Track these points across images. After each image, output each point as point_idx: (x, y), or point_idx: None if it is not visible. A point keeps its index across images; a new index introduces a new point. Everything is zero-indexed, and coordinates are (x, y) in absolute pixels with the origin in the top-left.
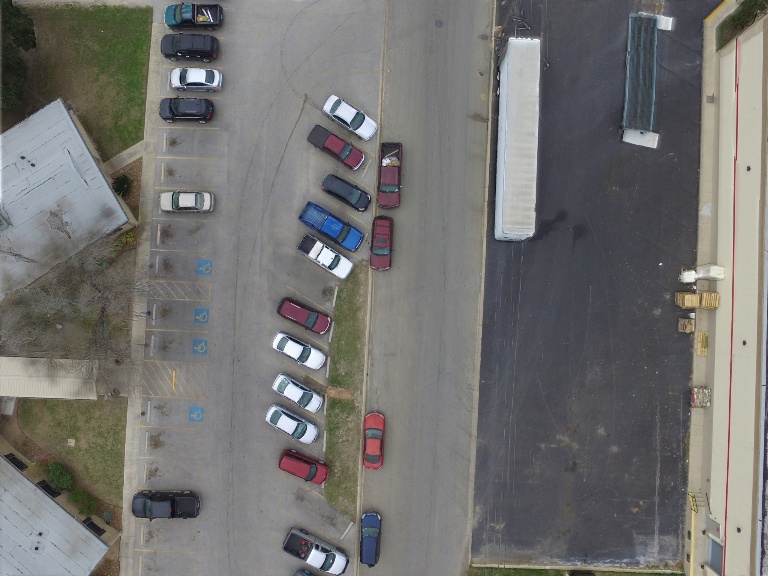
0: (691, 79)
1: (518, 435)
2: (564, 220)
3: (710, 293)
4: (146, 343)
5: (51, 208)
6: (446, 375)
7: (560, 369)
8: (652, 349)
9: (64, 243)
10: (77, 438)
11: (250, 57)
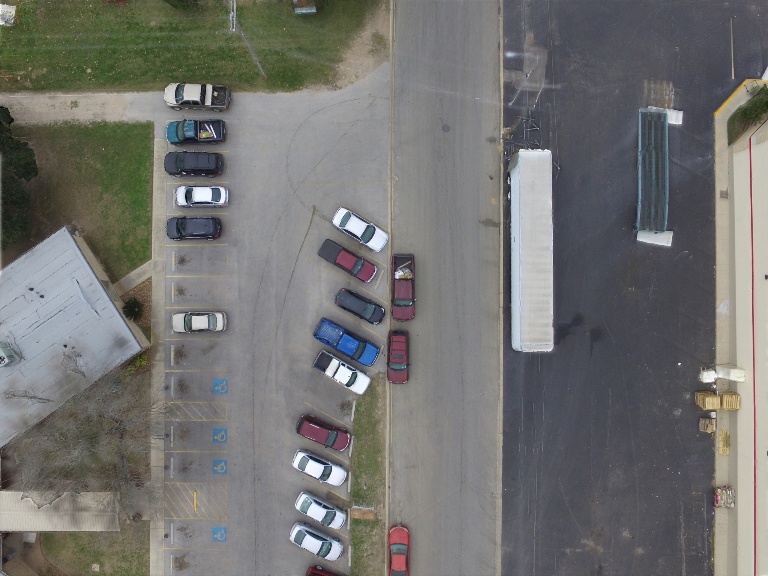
0: (704, 174)
1: (543, 541)
2: (581, 323)
3: (731, 395)
4: (165, 465)
5: (63, 340)
6: (468, 485)
7: (582, 473)
8: (674, 449)
9: (78, 375)
10: (101, 563)
11: (255, 170)
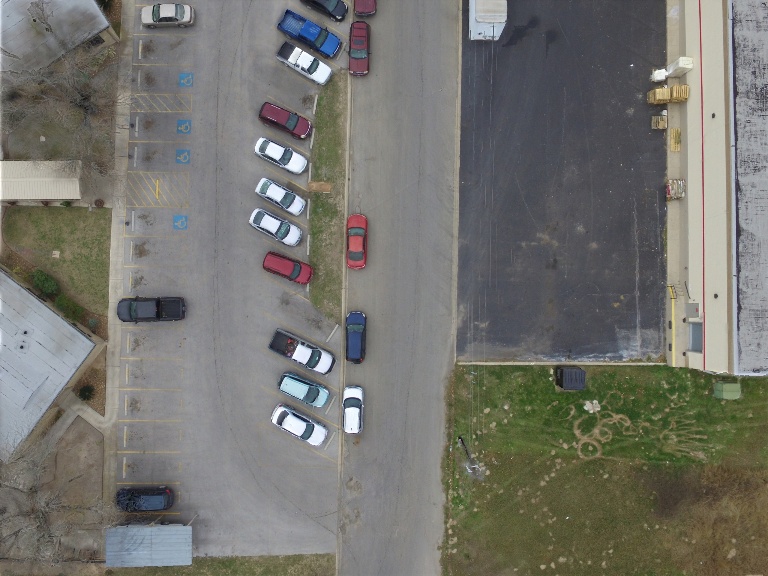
0: None
1: (499, 234)
2: (537, 26)
3: (680, 86)
4: (129, 155)
5: None
6: (426, 177)
7: (538, 169)
8: (627, 147)
9: (46, 49)
10: (62, 250)
11: None
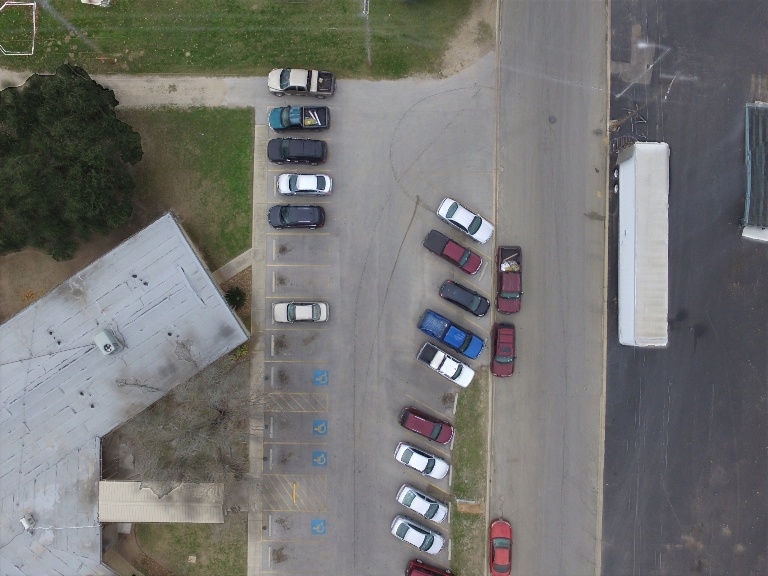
0: None
1: (643, 536)
2: (685, 319)
3: None
4: (264, 457)
5: (167, 328)
6: (570, 479)
7: (684, 469)
8: None
9: (182, 364)
10: (198, 555)
11: (358, 158)
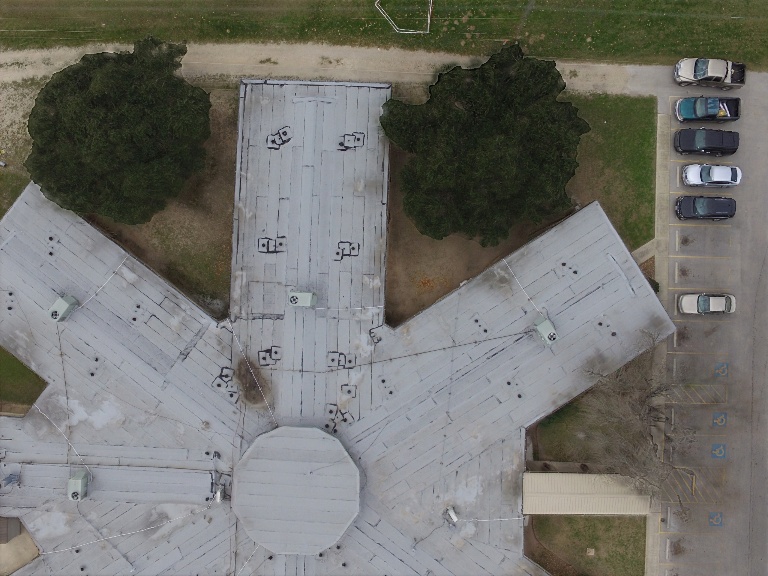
0: None
1: None
2: None
3: None
4: (665, 448)
5: (597, 318)
6: None
7: None
8: None
9: (611, 354)
10: (596, 547)
11: (759, 151)
